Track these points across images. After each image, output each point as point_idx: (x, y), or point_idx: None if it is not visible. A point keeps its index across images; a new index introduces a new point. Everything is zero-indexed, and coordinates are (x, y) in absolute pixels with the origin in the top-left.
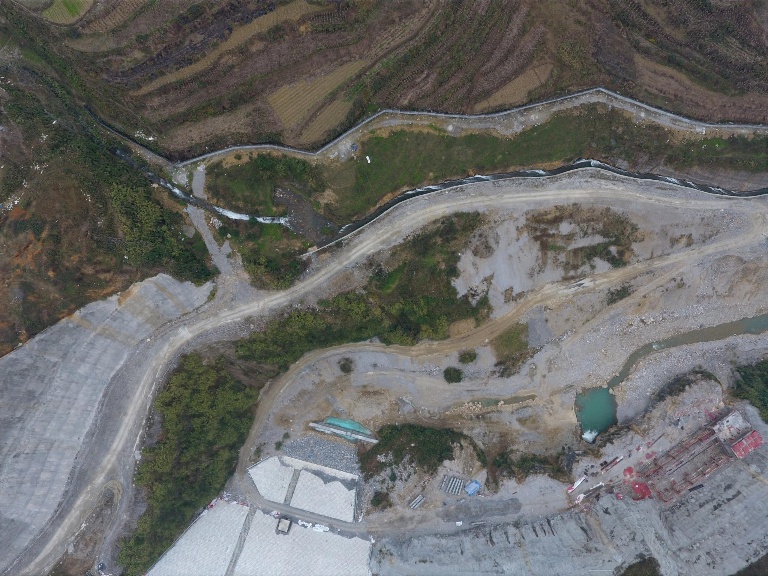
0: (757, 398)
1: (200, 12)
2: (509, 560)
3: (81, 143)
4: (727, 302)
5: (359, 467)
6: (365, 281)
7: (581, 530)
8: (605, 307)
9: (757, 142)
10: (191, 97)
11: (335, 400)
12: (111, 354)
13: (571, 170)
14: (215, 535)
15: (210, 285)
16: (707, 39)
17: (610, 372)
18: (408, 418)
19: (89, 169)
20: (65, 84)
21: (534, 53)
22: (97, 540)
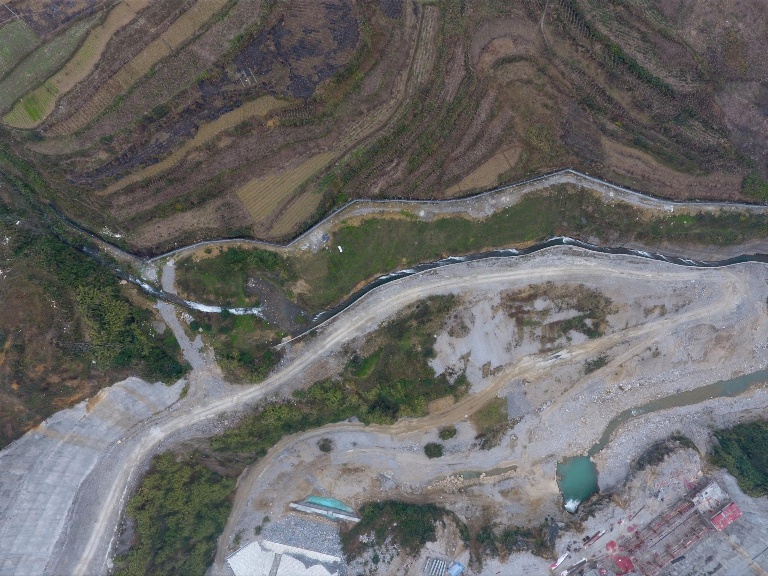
0: (734, 466)
1: (165, 112)
2: None
3: (45, 245)
4: (702, 366)
5: (341, 548)
6: (341, 368)
7: None
8: (583, 376)
9: (724, 218)
10: (158, 194)
11: (315, 479)
12: (80, 460)
13: (544, 248)
14: None
15: (182, 382)
16: (671, 122)
17: (590, 440)
18: (390, 494)
19: (54, 273)
20: (29, 182)
21: (503, 137)
22: None
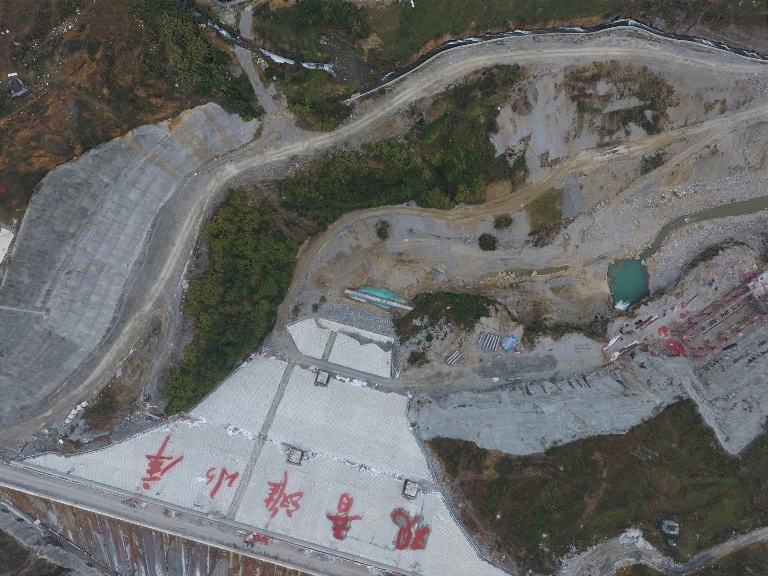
0: None
1: None
2: (548, 403)
3: None
4: (758, 176)
5: (395, 331)
6: (407, 129)
7: (617, 382)
8: (638, 177)
9: None
10: None
11: (371, 267)
12: (160, 184)
13: (609, 28)
14: (255, 383)
15: (257, 123)
16: None
17: (642, 243)
18: (442, 287)
19: None
20: None
21: None
22: (144, 370)
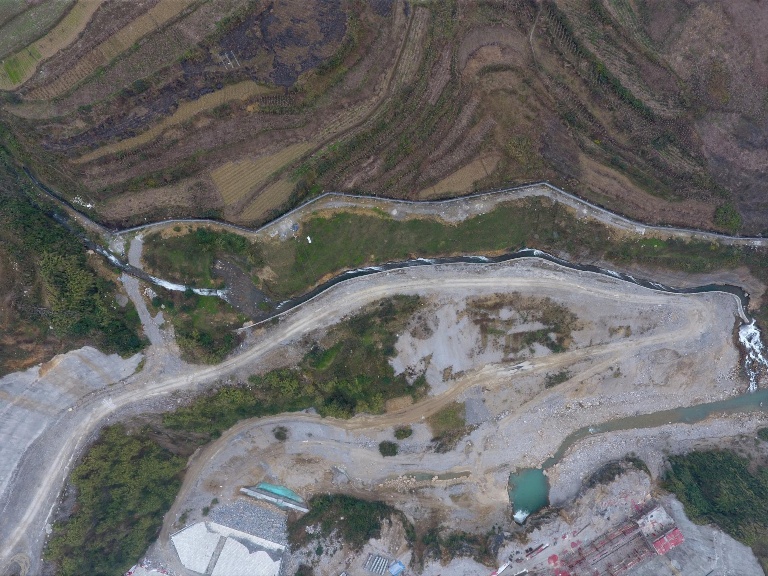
0: (683, 492)
1: (146, 87)
2: None
3: (15, 208)
4: (663, 391)
5: (287, 537)
6: (300, 358)
7: None
8: (543, 390)
9: (694, 246)
10: (132, 168)
11: (268, 466)
12: (29, 424)
13: (514, 258)
14: None
15: (139, 357)
16: (649, 146)
17: (545, 454)
18: (341, 488)
19: (20, 236)
20: (5, 144)
21: (482, 144)
22: None
